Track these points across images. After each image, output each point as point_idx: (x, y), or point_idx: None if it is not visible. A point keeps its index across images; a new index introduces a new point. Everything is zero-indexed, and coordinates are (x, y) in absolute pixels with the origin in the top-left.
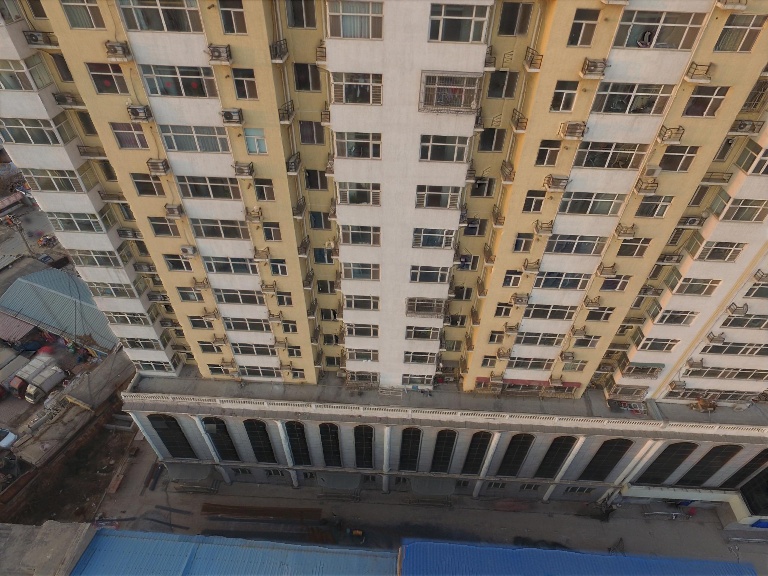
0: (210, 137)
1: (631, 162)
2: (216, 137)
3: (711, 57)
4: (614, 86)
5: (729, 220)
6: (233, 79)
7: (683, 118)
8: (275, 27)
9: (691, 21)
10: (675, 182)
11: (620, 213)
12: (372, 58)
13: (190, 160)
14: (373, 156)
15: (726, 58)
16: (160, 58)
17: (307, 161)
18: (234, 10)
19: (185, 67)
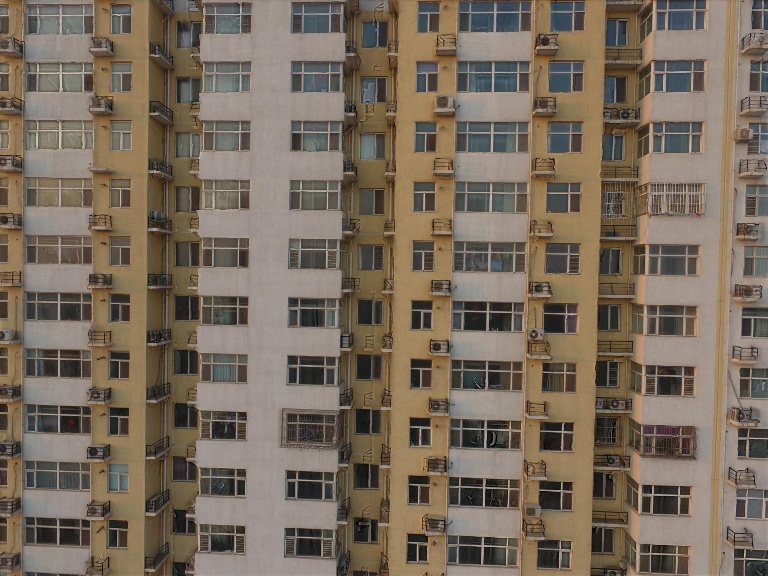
0: (73, 473)
1: (509, 500)
2: (79, 473)
3: (543, 397)
4: (464, 422)
5: (648, 572)
6: (109, 417)
7: (542, 453)
8: (161, 374)
9: (512, 368)
10: (564, 523)
11: (518, 563)
12: (237, 398)
13: (45, 499)
14: (238, 494)
15: (556, 397)
16: (46, 399)
17: (176, 500)
18: (121, 361)
19: (66, 406)
